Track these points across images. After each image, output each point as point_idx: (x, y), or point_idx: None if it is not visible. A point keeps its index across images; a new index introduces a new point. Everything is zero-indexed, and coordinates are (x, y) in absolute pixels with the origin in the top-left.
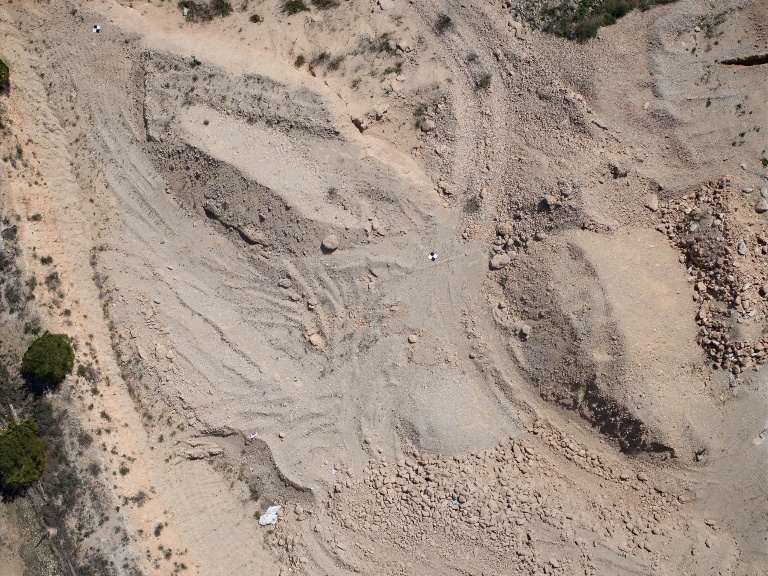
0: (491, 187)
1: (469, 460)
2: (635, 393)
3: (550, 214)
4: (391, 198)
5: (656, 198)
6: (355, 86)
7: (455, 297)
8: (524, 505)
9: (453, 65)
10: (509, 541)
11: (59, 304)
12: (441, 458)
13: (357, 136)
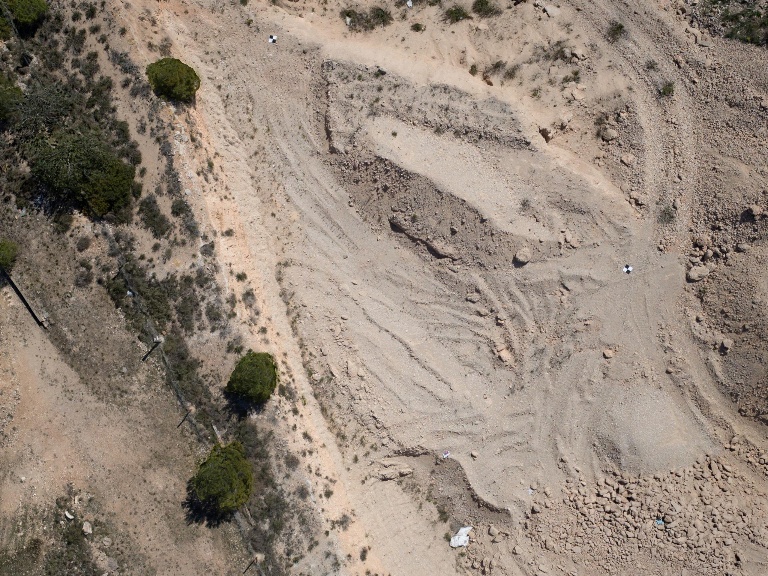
0: (684, 197)
1: (669, 478)
2: None
3: (754, 224)
4: (583, 209)
5: None
6: (536, 95)
7: (651, 310)
8: (730, 524)
9: (631, 73)
10: (719, 562)
11: (256, 322)
12: (641, 477)
13: (546, 146)
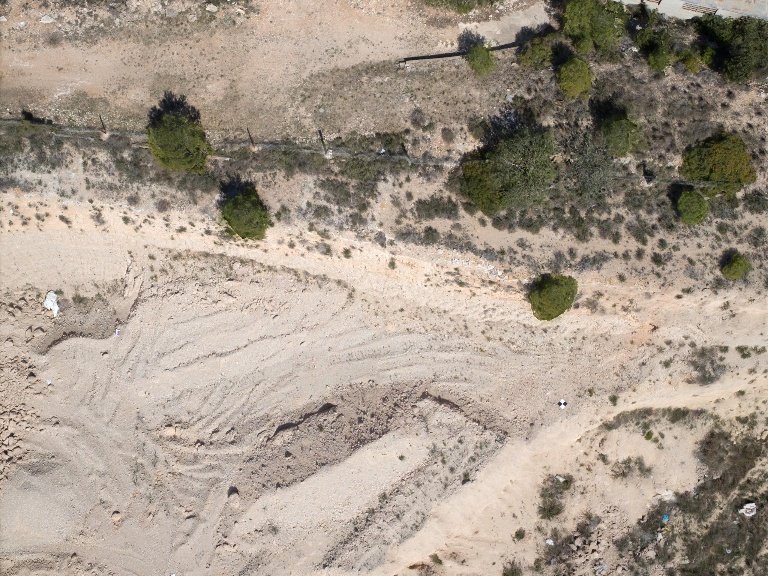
0: None
1: None
2: None
3: None
4: (243, 575)
5: None
6: None
7: (128, 575)
8: None
9: None
10: None
11: (302, 243)
12: None
13: None
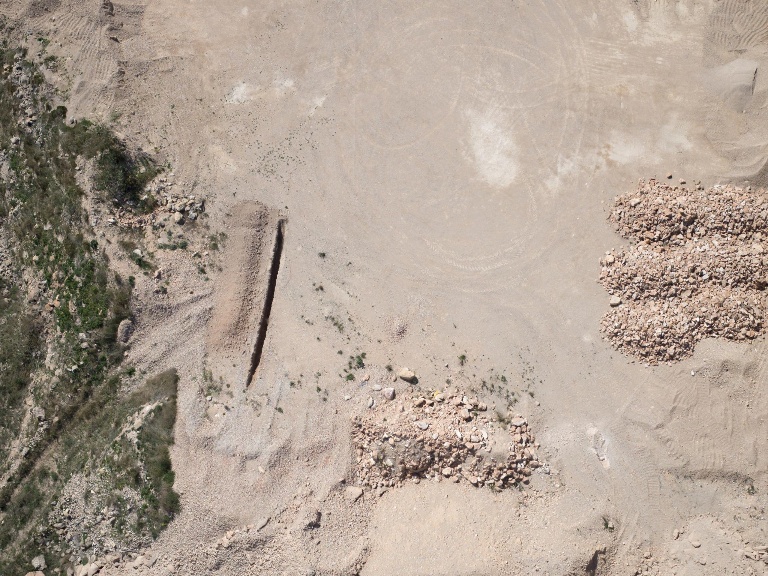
0: None
1: None
2: (533, 575)
3: None
4: None
5: (351, 488)
6: None
7: None
8: None
9: None
10: None
11: None
12: None
13: None
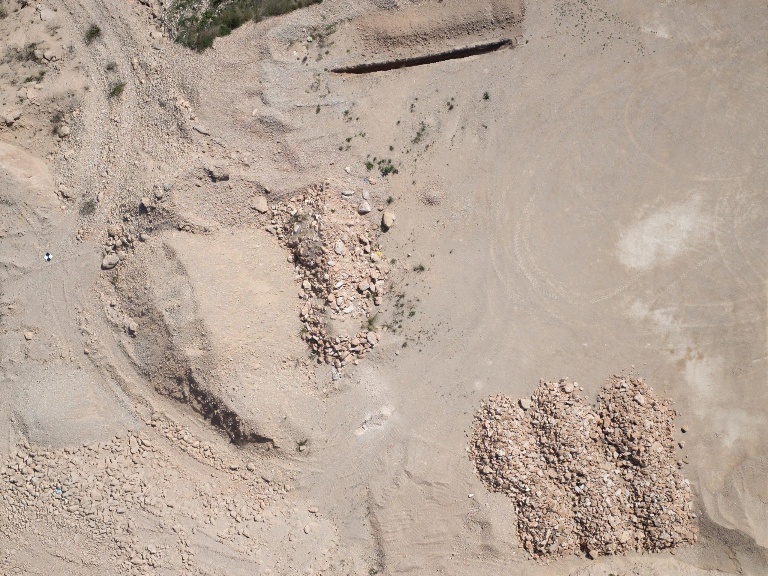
0: (108, 190)
1: (81, 451)
2: (229, 386)
3: (149, 216)
4: (9, 201)
5: (264, 200)
6: None
7: (69, 296)
8: (127, 494)
9: (95, 74)
10: (106, 528)
11: None
12: (52, 450)
13: None
